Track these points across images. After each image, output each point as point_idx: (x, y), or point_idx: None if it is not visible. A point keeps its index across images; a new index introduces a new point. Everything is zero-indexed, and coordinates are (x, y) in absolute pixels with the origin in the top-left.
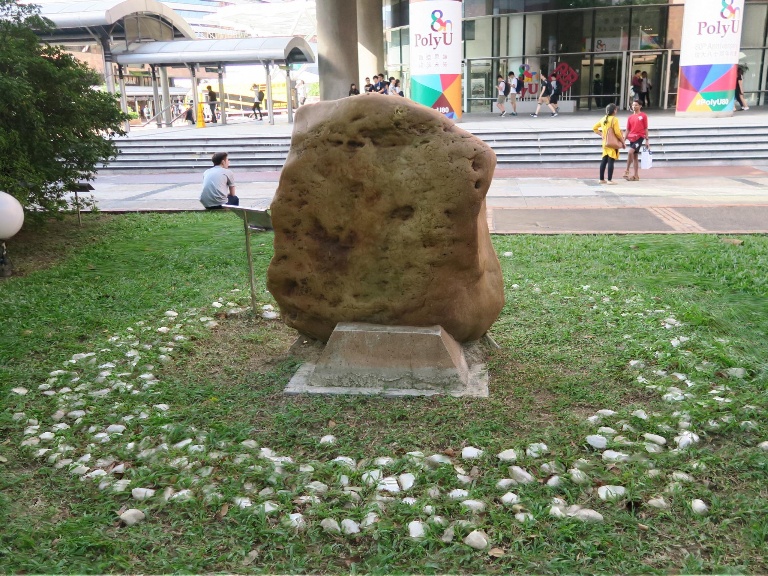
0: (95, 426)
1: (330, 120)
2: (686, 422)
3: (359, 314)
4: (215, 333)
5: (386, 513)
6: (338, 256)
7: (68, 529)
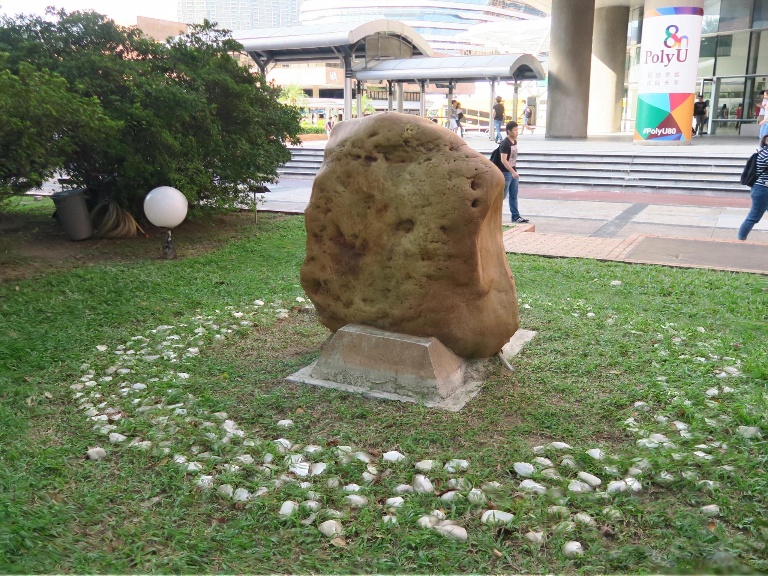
0: (126, 382)
1: (353, 136)
2: (639, 469)
3: (366, 318)
4: (279, 323)
5: (276, 490)
6: (352, 262)
7: (46, 452)
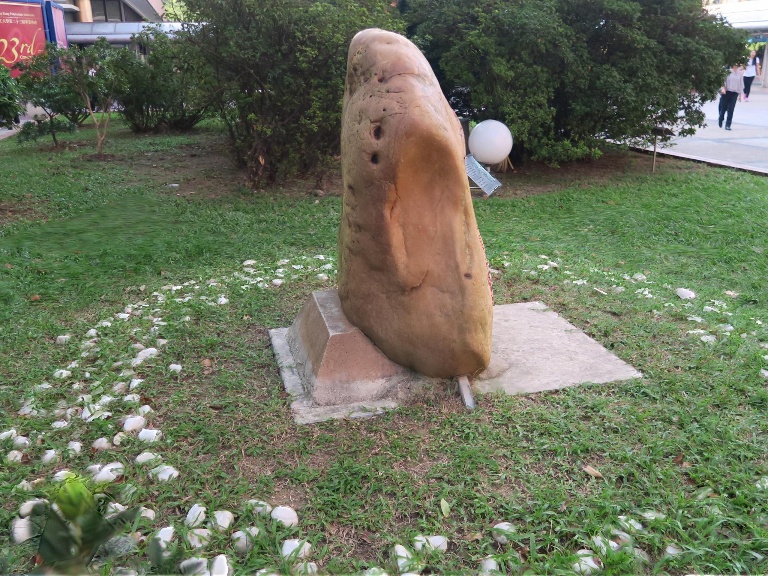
0: None
1: None
2: None
3: None
4: None
5: (39, 418)
6: None
7: (43, 327)
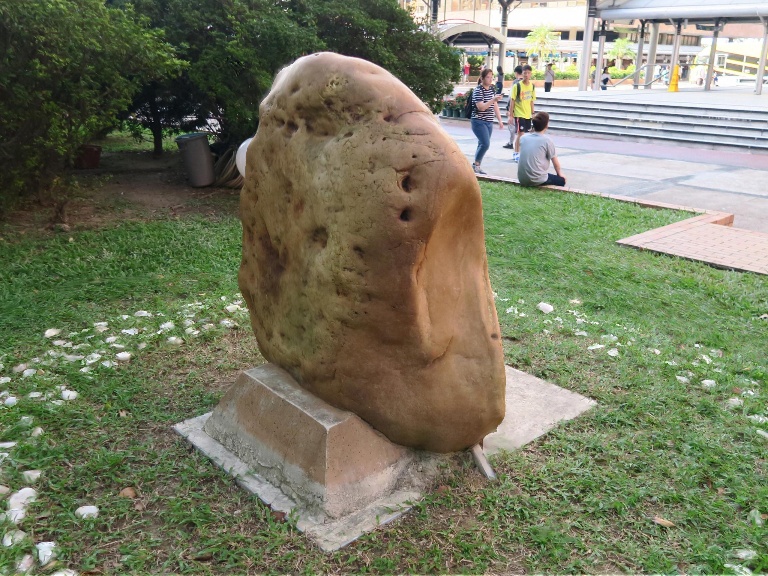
0: (6, 392)
1: (280, 90)
2: None
3: (283, 360)
4: None
5: None
6: (275, 276)
7: None
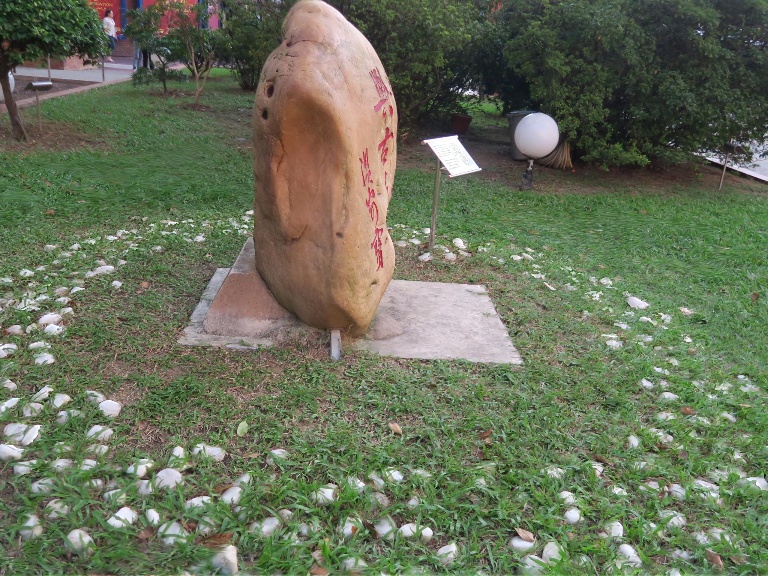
0: None
1: None
2: None
3: None
4: None
5: None
6: None
7: None
